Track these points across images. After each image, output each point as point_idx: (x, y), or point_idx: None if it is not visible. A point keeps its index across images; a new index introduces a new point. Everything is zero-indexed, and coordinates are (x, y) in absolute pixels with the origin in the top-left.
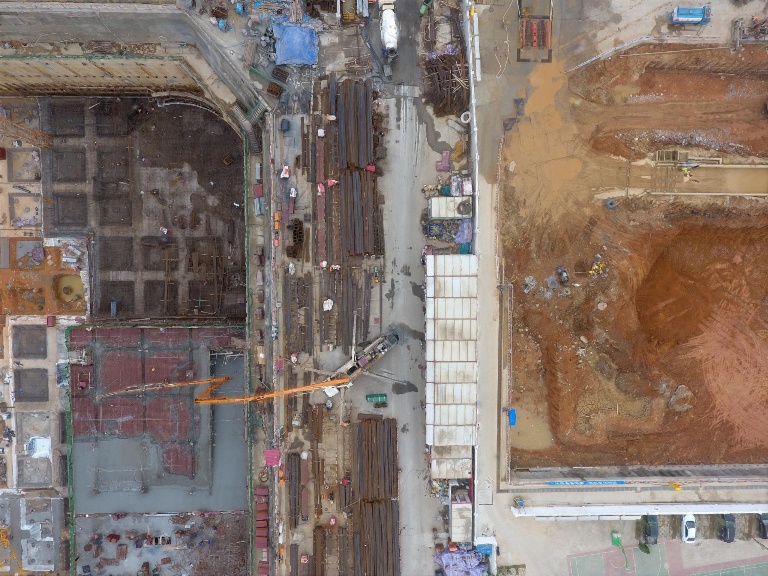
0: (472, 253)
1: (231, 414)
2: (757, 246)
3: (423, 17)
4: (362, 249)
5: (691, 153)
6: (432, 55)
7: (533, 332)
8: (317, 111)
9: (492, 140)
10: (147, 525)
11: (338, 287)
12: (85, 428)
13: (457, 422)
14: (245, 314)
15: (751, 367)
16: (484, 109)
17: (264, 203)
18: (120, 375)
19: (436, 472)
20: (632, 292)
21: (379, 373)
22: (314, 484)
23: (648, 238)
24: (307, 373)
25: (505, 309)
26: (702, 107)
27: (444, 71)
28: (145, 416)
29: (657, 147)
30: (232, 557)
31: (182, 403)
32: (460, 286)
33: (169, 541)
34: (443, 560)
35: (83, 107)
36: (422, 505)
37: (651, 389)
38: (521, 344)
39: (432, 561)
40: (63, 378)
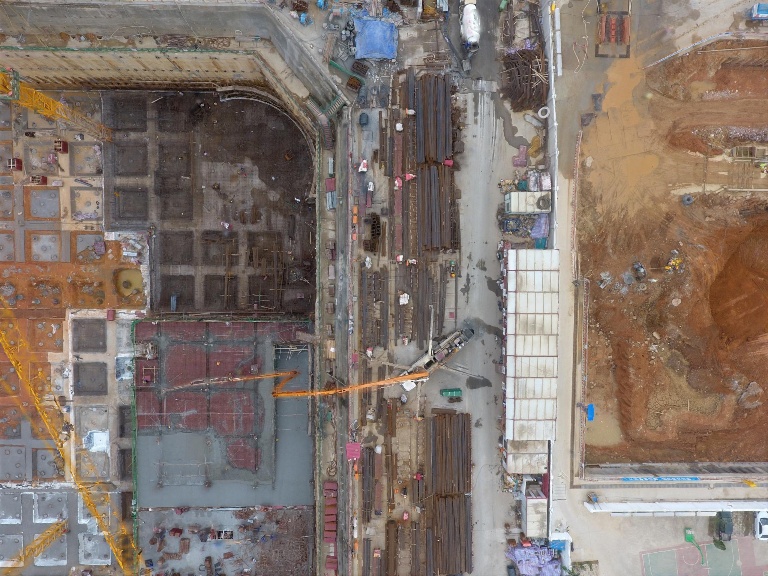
0: (548, 248)
1: (293, 409)
2: None
3: (502, 12)
4: (439, 243)
5: None
6: (511, 50)
7: (604, 328)
8: (395, 105)
9: (570, 135)
10: (210, 519)
11: (414, 281)
12: (149, 422)
13: (537, 417)
14: (305, 309)
15: None
16: (562, 104)
17: (338, 197)
18: (185, 369)
19: (512, 467)
20: (706, 288)
21: (453, 368)
22: (387, 478)
23: (723, 234)
24: (382, 367)
25: (580, 304)
26: None
27: (523, 66)
28: (209, 410)
29: (734, 143)
30: (296, 552)
31: (246, 397)
32: (542, 280)
33: (231, 535)
34: (516, 555)
35: (145, 101)
36: (494, 500)
37: (723, 386)
38: (592, 340)
39: (504, 556)
40: (121, 372)
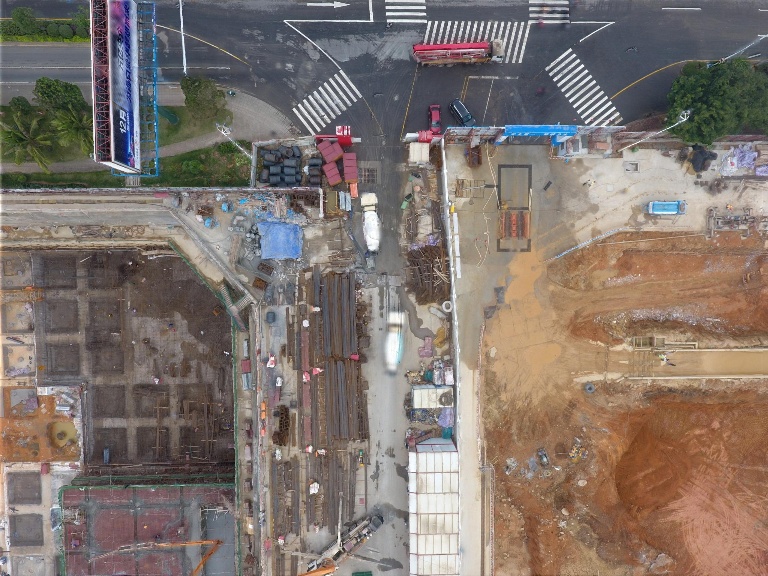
0: (454, 436)
1: (222, 565)
2: (735, 412)
3: (405, 210)
4: (347, 435)
5: (668, 339)
6: (414, 247)
7: (516, 502)
8: (302, 301)
9: (473, 328)
10: None
11: (324, 470)
12: None
13: None
14: None
15: (730, 529)
16: (465, 298)
17: (251, 384)
18: (113, 532)
19: None
20: (612, 468)
21: (365, 551)
22: None
23: (627, 418)
24: None
25: (487, 489)
26: (679, 284)
27: (425, 264)
28: (138, 571)
29: (635, 331)
30: None
31: (174, 558)
32: (442, 482)
33: None
34: None
35: (75, 259)
36: None
37: (631, 559)
38: (504, 513)
39: None
40: (58, 521)
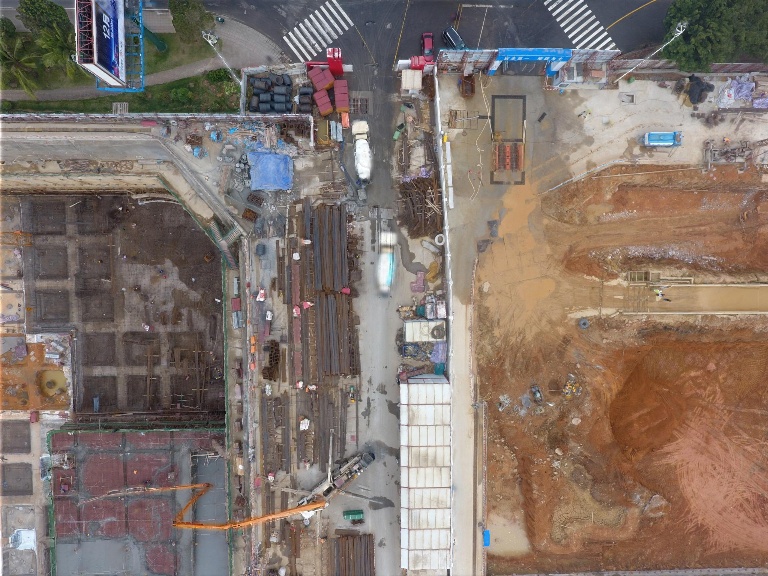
0: (447, 372)
1: (213, 512)
2: (731, 354)
3: (397, 141)
4: (338, 370)
5: (663, 273)
6: (406, 179)
7: (509, 443)
8: (292, 234)
9: (466, 262)
10: None
11: (314, 407)
12: (68, 530)
13: (431, 546)
14: None
15: (725, 472)
16: (458, 231)
17: (241, 320)
18: (102, 477)
19: None
20: (606, 407)
21: (356, 489)
22: None
23: (621, 355)
24: None
25: (480, 426)
26: (675, 222)
27: (418, 196)
28: (127, 517)
29: (630, 266)
30: None
31: (164, 504)
32: (433, 414)
33: None
34: None
35: (64, 205)
36: None
37: (625, 499)
38: (497, 454)
39: None
40: (47, 471)
